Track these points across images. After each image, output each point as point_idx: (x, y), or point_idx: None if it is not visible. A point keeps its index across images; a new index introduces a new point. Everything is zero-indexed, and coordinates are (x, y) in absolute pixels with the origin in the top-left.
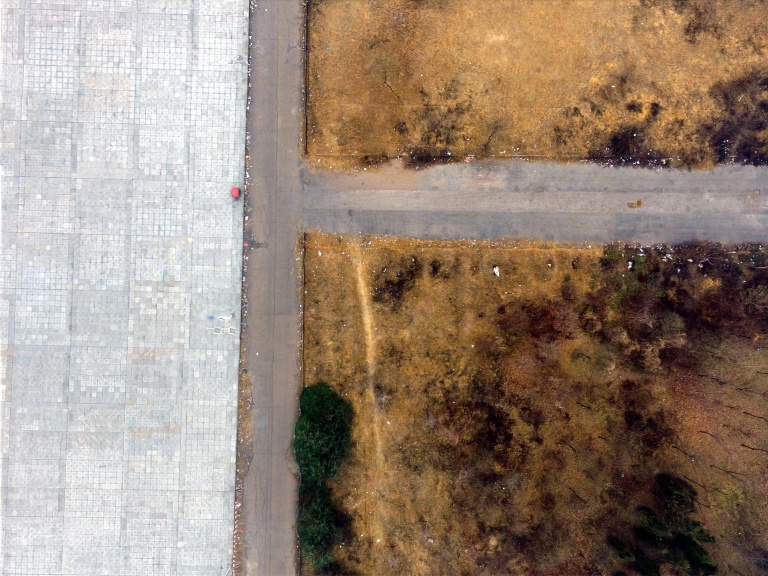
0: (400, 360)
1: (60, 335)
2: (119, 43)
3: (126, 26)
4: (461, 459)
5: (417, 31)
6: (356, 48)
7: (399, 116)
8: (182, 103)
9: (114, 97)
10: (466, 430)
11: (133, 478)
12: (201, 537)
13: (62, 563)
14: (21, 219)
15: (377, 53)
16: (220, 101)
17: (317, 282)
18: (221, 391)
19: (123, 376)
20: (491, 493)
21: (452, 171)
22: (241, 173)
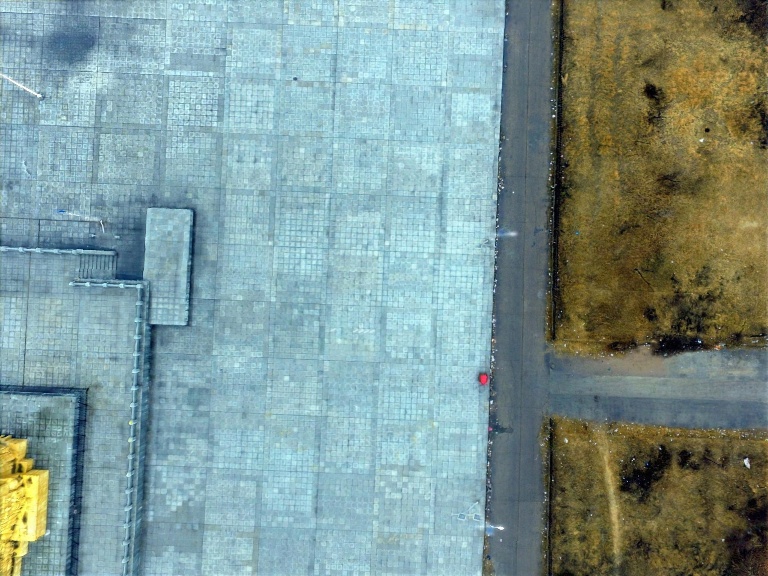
0: (648, 552)
1: (306, 518)
2: (368, 225)
3: (375, 208)
4: None
5: (669, 217)
6: (606, 234)
7: (649, 303)
8: (429, 286)
9: (362, 279)
10: None
11: None
12: None
13: None
14: (269, 400)
15: (627, 239)
16: (467, 285)
17: (564, 470)
18: None
19: (368, 560)
20: None
21: (701, 359)
22: (488, 358)
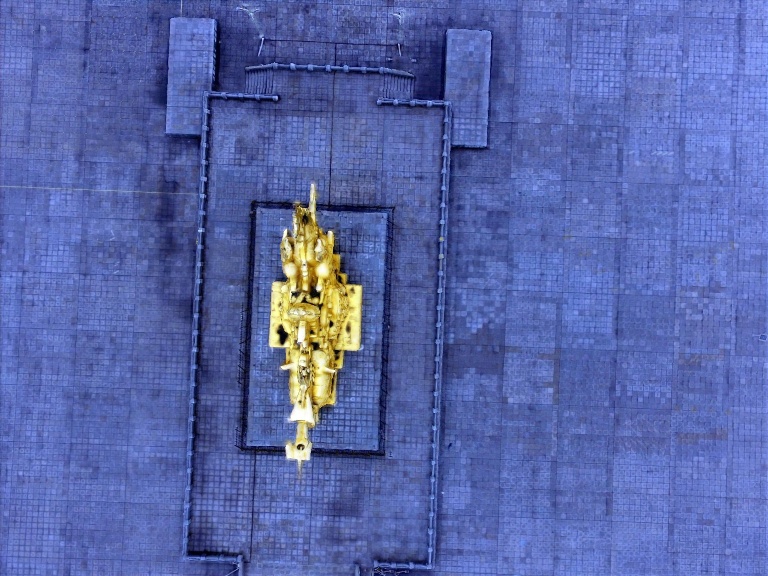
0: None
1: (606, 339)
2: (666, 47)
3: (673, 30)
4: None
5: None
6: None
7: None
8: (728, 108)
9: (660, 101)
10: None
11: (680, 484)
12: (749, 545)
13: (611, 567)
14: (568, 223)
15: None
16: (767, 106)
17: None
18: (767, 398)
19: (669, 381)
20: None
21: None
22: None
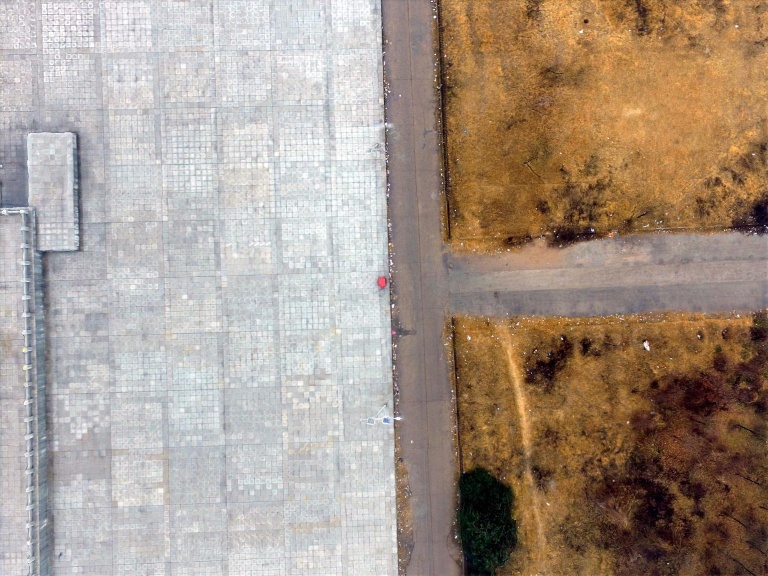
0: (556, 440)
1: (214, 435)
2: (256, 138)
3: (262, 120)
4: (626, 538)
5: (554, 109)
6: (494, 130)
7: (540, 195)
8: (322, 194)
9: (254, 192)
10: (630, 509)
11: (296, 574)
12: None
13: None
14: (168, 320)
15: (515, 133)
16: (360, 190)
17: (468, 367)
18: (379, 482)
19: (280, 472)
20: (655, 569)
21: (596, 247)
22: (385, 261)
